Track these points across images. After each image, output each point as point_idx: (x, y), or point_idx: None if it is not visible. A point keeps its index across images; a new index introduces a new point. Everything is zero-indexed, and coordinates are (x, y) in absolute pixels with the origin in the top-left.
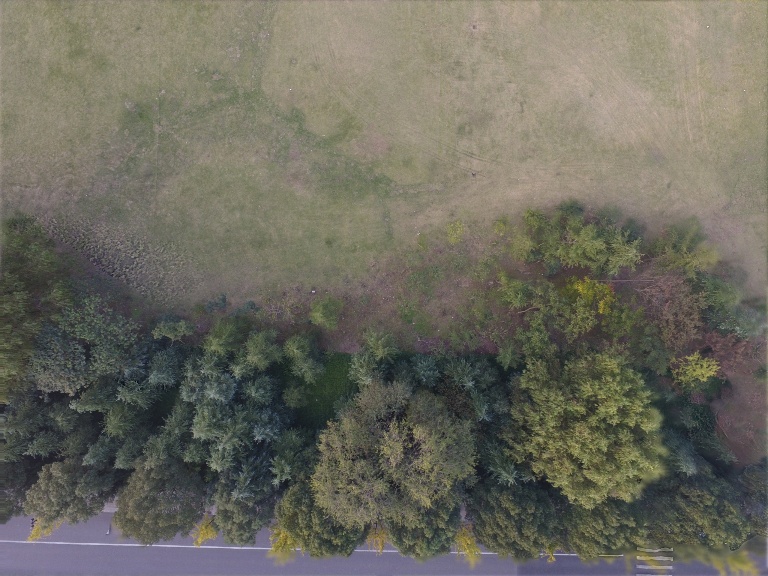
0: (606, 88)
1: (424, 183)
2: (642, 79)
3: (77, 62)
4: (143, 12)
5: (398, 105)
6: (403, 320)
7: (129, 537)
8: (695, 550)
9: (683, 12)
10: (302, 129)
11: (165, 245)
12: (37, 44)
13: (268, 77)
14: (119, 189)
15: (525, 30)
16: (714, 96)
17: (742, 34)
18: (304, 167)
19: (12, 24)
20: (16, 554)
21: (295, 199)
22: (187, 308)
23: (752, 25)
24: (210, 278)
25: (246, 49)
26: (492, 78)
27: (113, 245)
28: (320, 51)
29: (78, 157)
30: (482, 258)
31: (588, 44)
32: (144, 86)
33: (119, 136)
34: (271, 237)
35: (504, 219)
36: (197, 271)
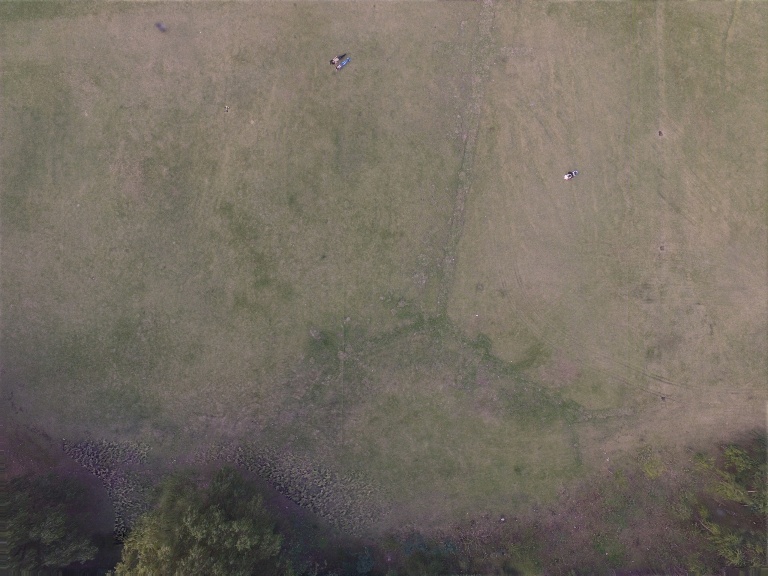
0: None
1: (613, 408)
2: None
3: (263, 292)
4: (328, 240)
5: (586, 330)
6: (596, 550)
7: None
8: None
9: None
10: (489, 355)
11: (353, 474)
12: (222, 274)
13: (454, 303)
14: (305, 418)
15: (713, 250)
16: None
17: None
18: (491, 394)
19: (196, 253)
20: None
21: (483, 427)
22: (375, 537)
23: None
24: (398, 506)
25: (431, 275)
26: (681, 300)
27: (300, 474)
28: (507, 277)
29: (264, 386)
30: (676, 487)
31: None
32: (329, 314)
33: (304, 364)
34: (460, 466)
35: (696, 445)
36: (385, 499)
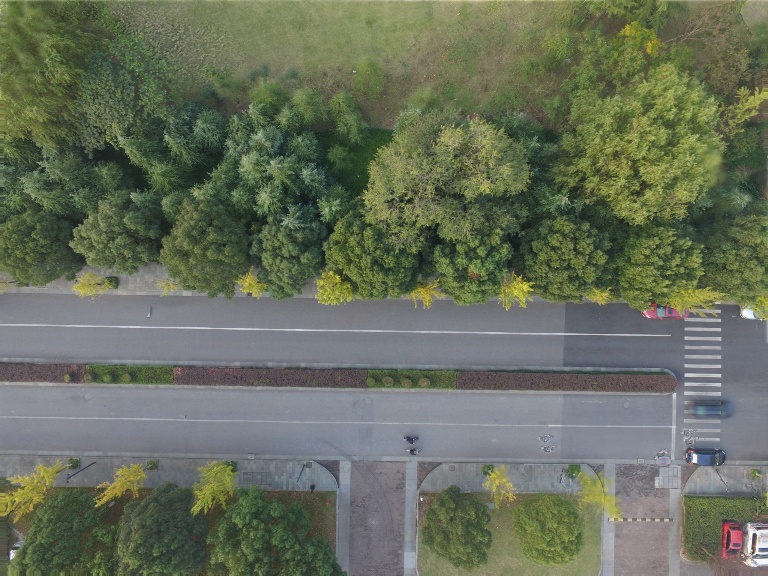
0: None
1: None
2: None
3: None
4: None
5: None
6: (445, 96)
7: (170, 320)
8: (744, 328)
9: None
10: None
11: (206, 27)
12: None
13: None
14: None
15: None
16: None
17: None
18: None
19: None
20: (56, 338)
21: None
22: (228, 89)
23: None
24: (250, 60)
25: None
26: None
27: (154, 28)
28: None
29: None
30: (523, 33)
31: None
32: None
33: None
34: (311, 17)
35: None
36: (237, 53)
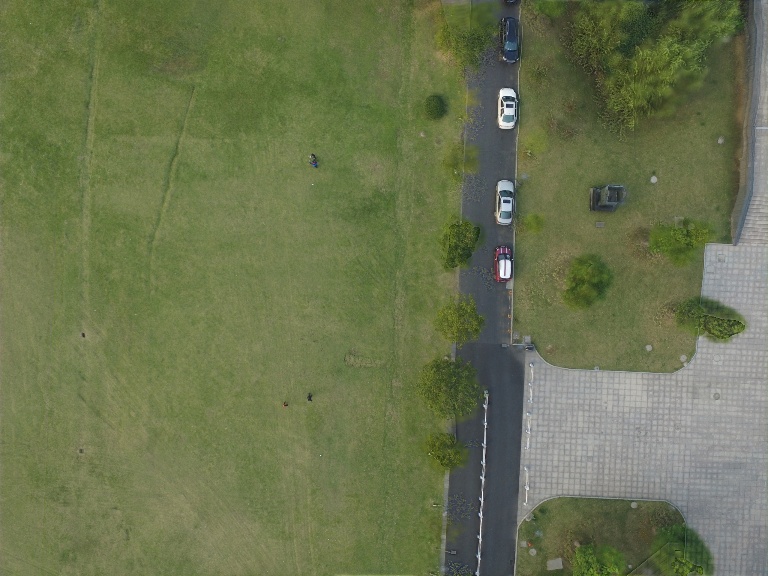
0: (211, 519)
1: None
2: (250, 510)
3: None
4: None
5: None
6: None
7: None
8: None
9: (295, 441)
10: None
11: None
12: None
13: None
14: None
15: (132, 456)
16: (325, 528)
17: (357, 463)
18: None
19: None
20: None
21: None
22: None
23: (368, 454)
24: None
25: None
26: (97, 504)
27: None
28: None
29: None
30: None
31: (195, 473)
32: None
33: None
34: None
35: None
36: None
